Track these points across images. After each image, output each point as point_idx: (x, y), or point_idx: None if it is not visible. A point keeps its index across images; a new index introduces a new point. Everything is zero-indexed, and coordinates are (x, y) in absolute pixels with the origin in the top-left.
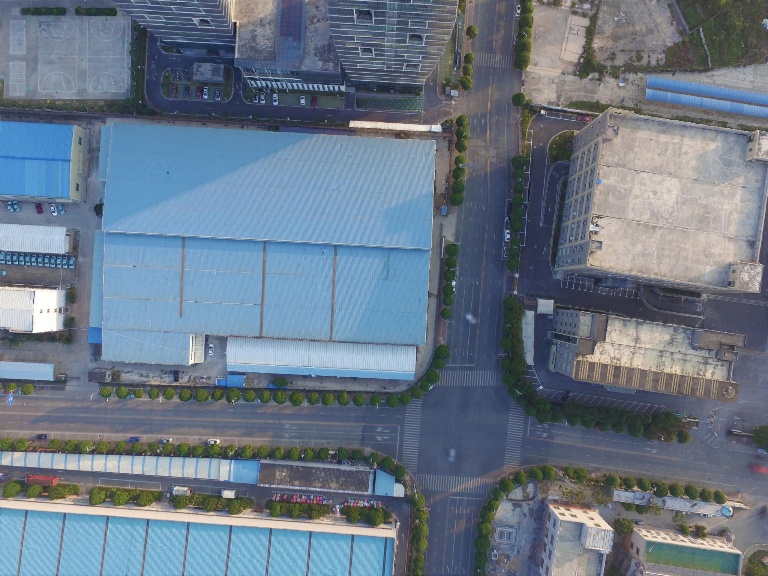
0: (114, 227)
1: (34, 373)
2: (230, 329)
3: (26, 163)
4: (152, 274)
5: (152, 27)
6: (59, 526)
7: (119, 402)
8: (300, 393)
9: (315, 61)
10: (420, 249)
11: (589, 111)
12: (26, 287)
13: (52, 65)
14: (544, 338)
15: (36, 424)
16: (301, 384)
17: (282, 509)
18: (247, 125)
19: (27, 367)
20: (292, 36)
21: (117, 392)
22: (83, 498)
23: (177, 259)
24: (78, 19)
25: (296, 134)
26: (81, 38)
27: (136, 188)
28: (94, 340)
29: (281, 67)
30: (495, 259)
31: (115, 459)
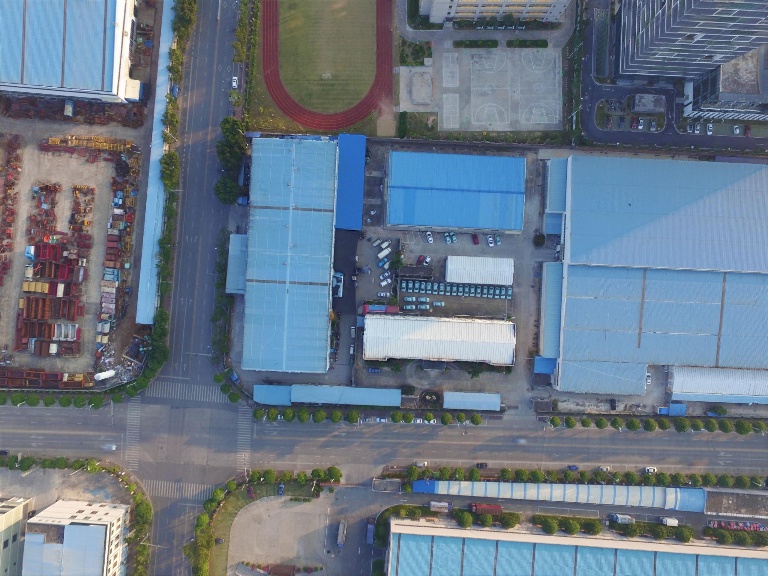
0: (581, 259)
1: (482, 403)
2: (687, 359)
3: (481, 196)
4: (612, 305)
5: (639, 62)
6: (530, 556)
7: (556, 431)
8: (747, 422)
9: None
10: None
11: None
12: (474, 318)
13: (485, 97)
14: None
15: (475, 453)
16: (735, 412)
17: (732, 537)
18: (679, 155)
19: (474, 397)
20: None
21: (570, 422)
22: (529, 527)
23: (638, 290)
24: (509, 51)
25: (752, 165)
26: (513, 70)
27: (600, 220)
28: (541, 370)
29: (765, 100)
30: None
31: (560, 488)
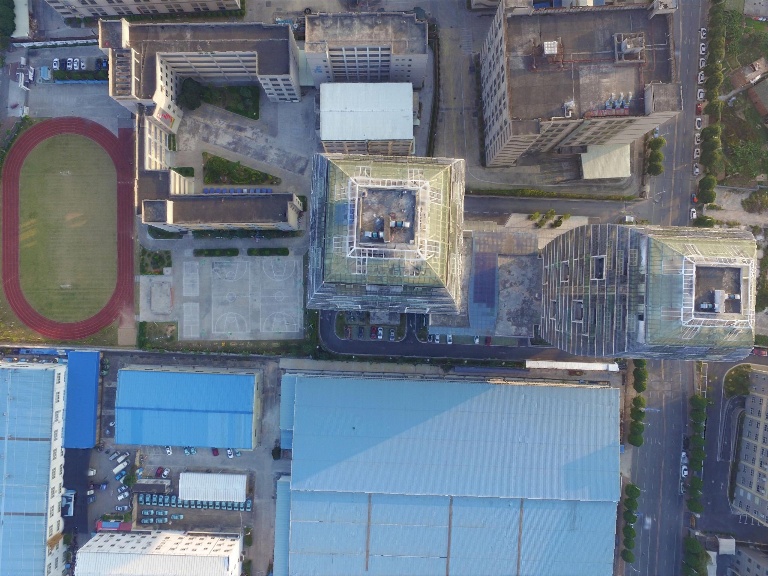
0: (303, 486)
1: None
2: None
3: (209, 416)
4: (338, 529)
5: None
6: None
7: None
8: None
9: (508, 326)
10: (607, 501)
11: (766, 346)
12: (207, 536)
13: (225, 306)
14: (723, 575)
15: None
16: None
17: None
18: None
19: None
20: (486, 302)
21: None
22: None
23: (363, 514)
24: (250, 259)
25: (480, 385)
26: (254, 278)
27: (323, 445)
28: None
29: (475, 333)
30: (672, 494)
31: None
